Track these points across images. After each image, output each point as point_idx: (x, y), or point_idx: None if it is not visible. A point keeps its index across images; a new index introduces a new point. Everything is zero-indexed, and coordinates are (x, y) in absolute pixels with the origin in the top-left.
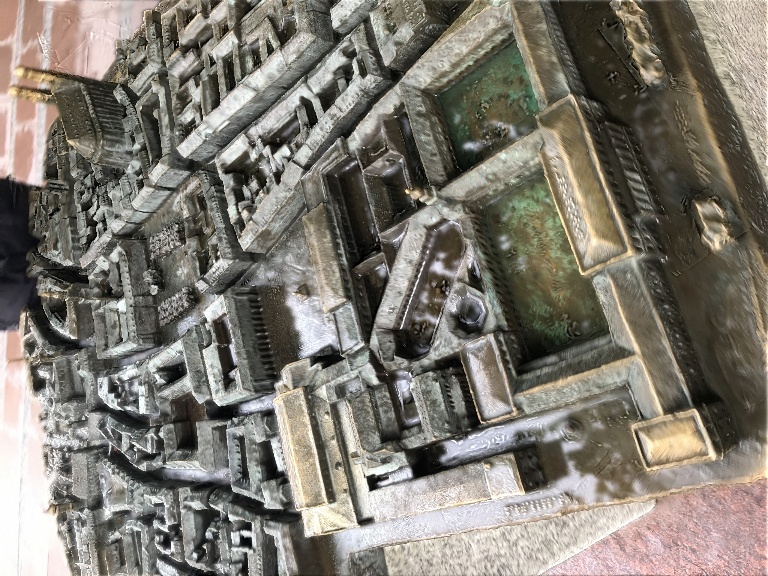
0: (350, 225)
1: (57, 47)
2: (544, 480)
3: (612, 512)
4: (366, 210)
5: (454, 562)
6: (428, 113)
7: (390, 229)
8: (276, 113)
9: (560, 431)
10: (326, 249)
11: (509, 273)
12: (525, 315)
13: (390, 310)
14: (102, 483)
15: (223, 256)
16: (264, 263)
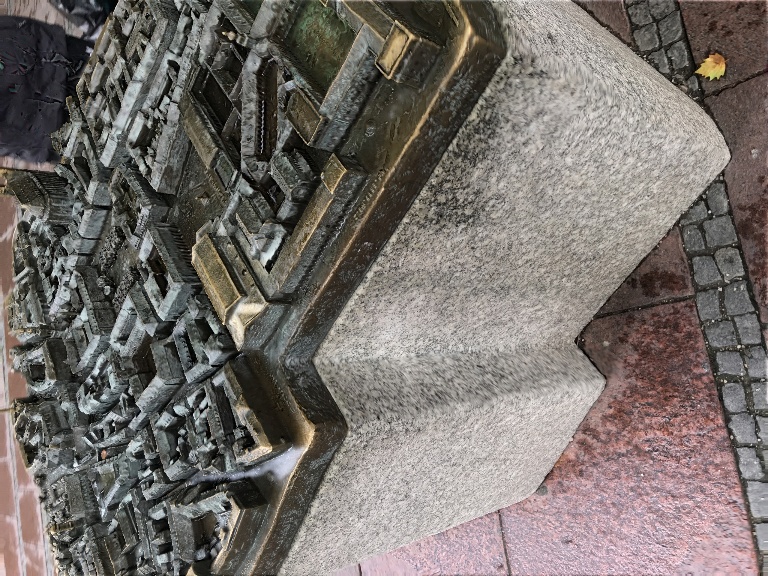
0: (216, 116)
1: None
2: (365, 171)
3: (555, 377)
4: (226, 105)
5: (388, 382)
6: (237, 6)
7: (234, 88)
8: (155, 82)
9: (365, 134)
10: (198, 127)
11: (310, 68)
12: (326, 84)
13: (249, 141)
14: (95, 488)
15: (143, 205)
16: (177, 203)
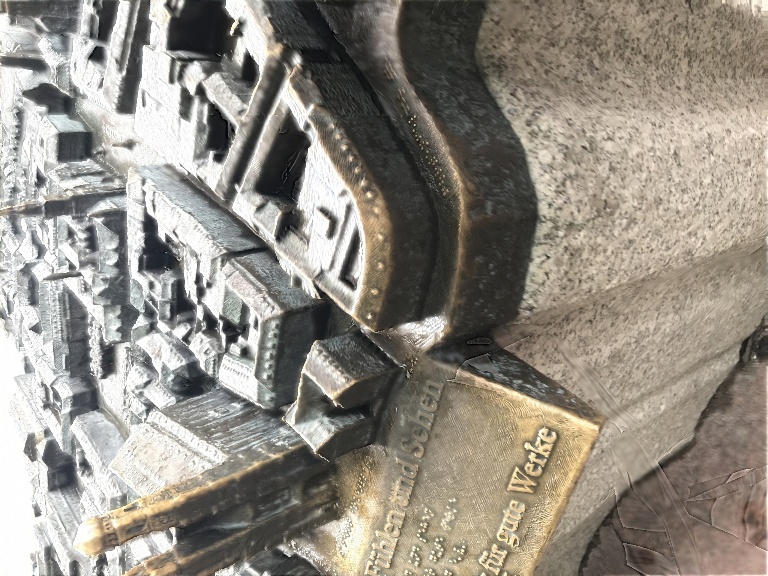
0: None
1: None
2: None
3: None
4: None
5: None
6: None
7: None
8: None
9: None
10: None
11: None
12: None
13: None
14: None
15: None
16: None
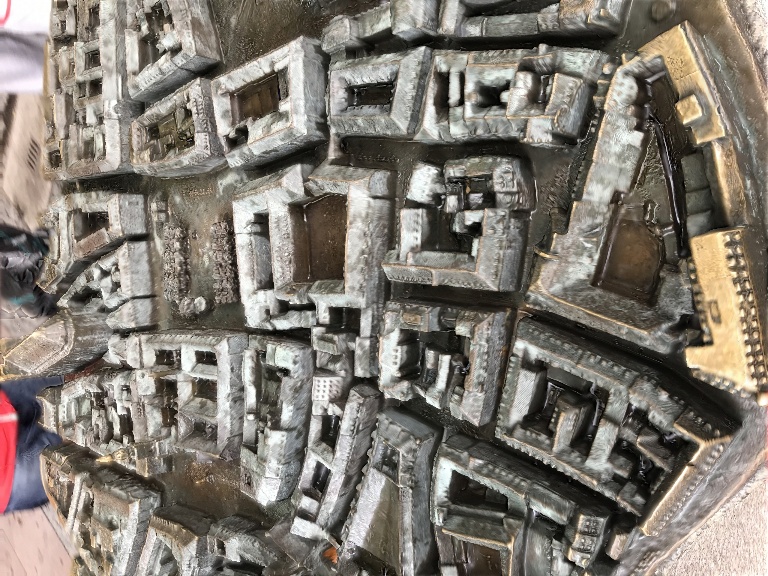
0: None
1: (13, 435)
2: None
3: None
4: None
5: None
6: None
7: None
8: None
9: None
10: None
11: None
12: None
13: None
14: None
15: (188, 86)
16: (229, 69)
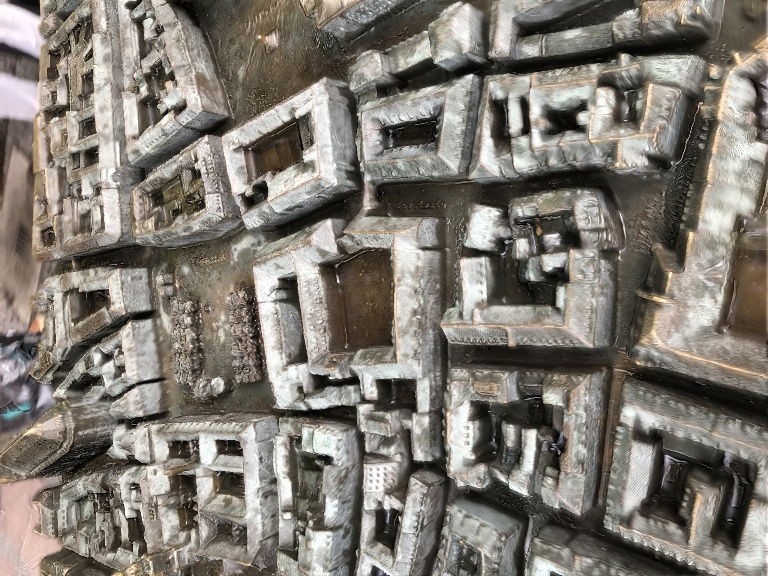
0: None
1: (6, 546)
2: None
3: None
4: None
5: None
6: None
7: None
8: (124, 41)
9: None
10: None
11: None
12: None
13: None
14: None
15: (195, 145)
16: (238, 124)
